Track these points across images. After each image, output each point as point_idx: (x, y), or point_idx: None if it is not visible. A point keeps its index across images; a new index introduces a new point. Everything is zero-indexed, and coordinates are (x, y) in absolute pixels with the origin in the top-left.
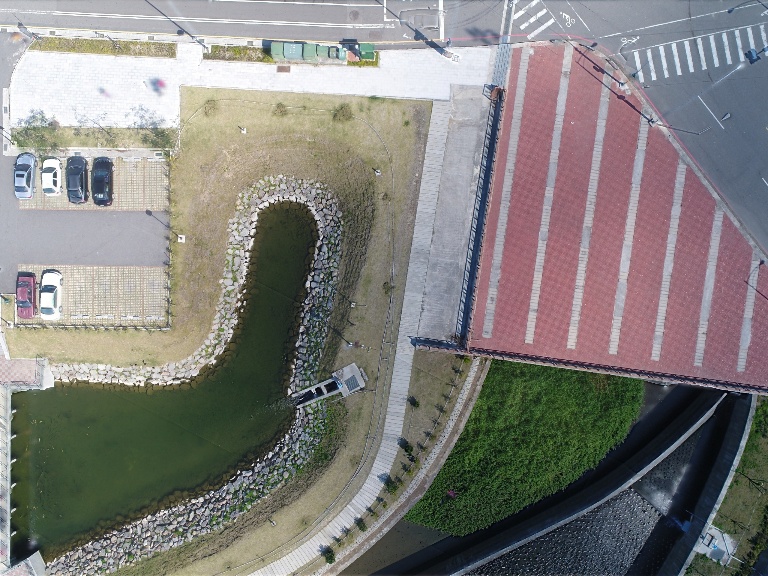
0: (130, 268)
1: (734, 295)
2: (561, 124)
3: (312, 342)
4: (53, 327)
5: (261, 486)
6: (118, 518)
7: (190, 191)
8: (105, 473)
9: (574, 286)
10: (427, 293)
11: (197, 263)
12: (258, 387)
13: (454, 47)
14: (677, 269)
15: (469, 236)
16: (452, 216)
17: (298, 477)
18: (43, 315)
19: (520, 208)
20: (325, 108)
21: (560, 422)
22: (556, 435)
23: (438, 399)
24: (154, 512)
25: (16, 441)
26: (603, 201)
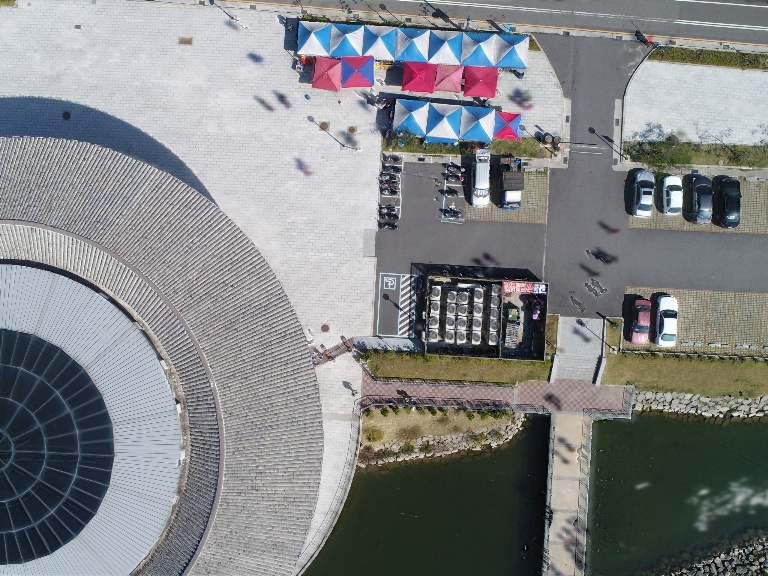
0: (748, 294)
1: None
2: None
3: None
4: (663, 354)
5: None
6: (684, 555)
7: None
8: (667, 507)
9: None
10: None
11: None
12: None
13: None
14: None
15: None
16: None
17: None
18: (663, 341)
19: None
20: None
21: None
22: None
23: None
24: (726, 551)
25: None
26: None
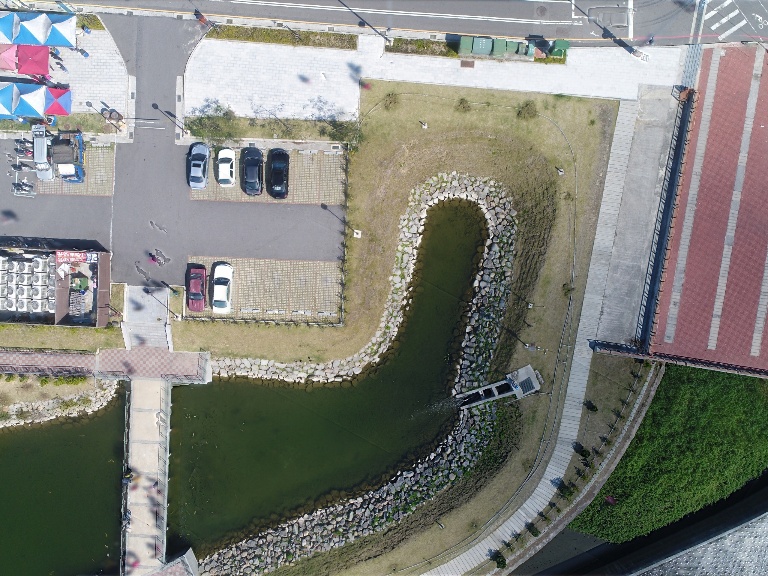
0: (303, 262)
1: None
2: (751, 127)
3: (481, 342)
4: (222, 320)
5: (425, 488)
6: (273, 516)
7: (367, 186)
8: (259, 470)
9: (759, 292)
10: (607, 296)
11: (370, 259)
12: (419, 387)
13: (643, 46)
14: None
15: (652, 239)
16: (635, 218)
17: (466, 479)
18: (215, 308)
19: (706, 212)
20: (509, 105)
21: (726, 430)
22: (723, 443)
23: (615, 404)
24: (310, 511)
25: (172, 435)
26: None
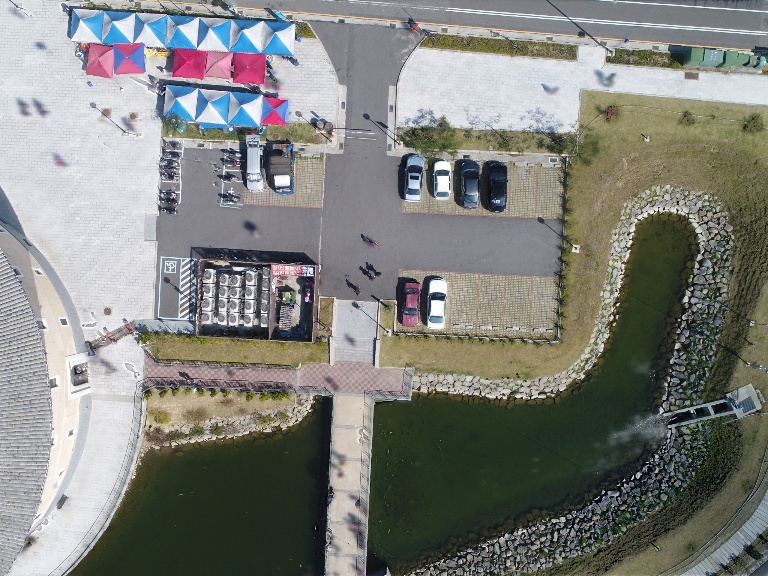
0: (518, 277)
1: None
2: None
3: (693, 360)
4: (435, 336)
5: (635, 508)
6: (471, 535)
7: (587, 199)
8: (456, 488)
9: None
10: None
11: (586, 274)
12: (622, 404)
13: None
14: None
15: None
16: None
17: (679, 500)
18: (431, 324)
19: None
20: (734, 118)
21: None
22: None
23: None
24: (510, 531)
25: None
26: None
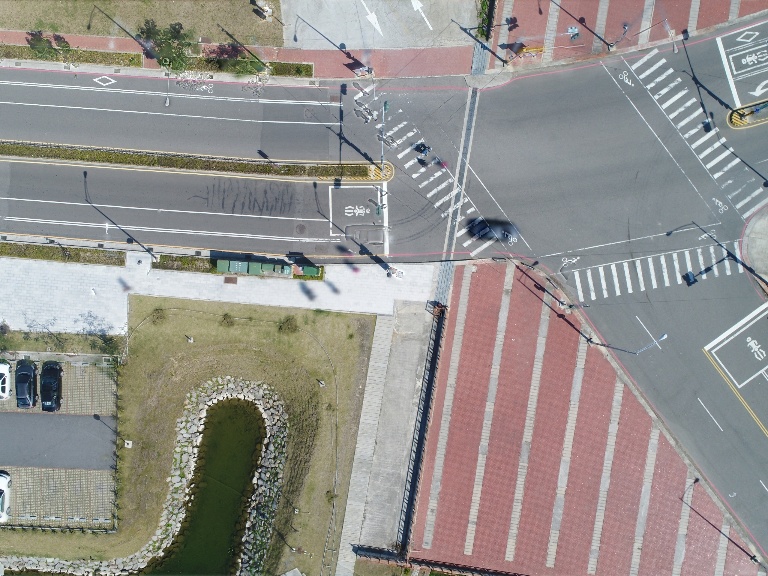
0: (77, 471)
1: (669, 512)
2: (502, 341)
3: (258, 540)
4: (1, 527)
5: None
6: None
7: (137, 397)
8: None
9: (513, 500)
10: (369, 502)
11: (144, 465)
12: None
13: (398, 263)
14: (614, 485)
15: (411, 447)
16: (394, 427)
17: None
18: None
19: (461, 422)
20: (271, 320)
21: None
22: None
23: None
24: None
25: None
26: (542, 417)
